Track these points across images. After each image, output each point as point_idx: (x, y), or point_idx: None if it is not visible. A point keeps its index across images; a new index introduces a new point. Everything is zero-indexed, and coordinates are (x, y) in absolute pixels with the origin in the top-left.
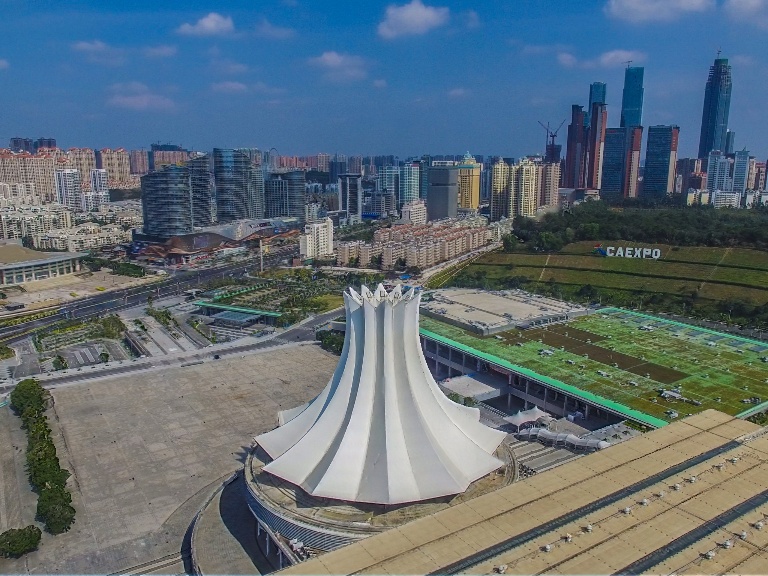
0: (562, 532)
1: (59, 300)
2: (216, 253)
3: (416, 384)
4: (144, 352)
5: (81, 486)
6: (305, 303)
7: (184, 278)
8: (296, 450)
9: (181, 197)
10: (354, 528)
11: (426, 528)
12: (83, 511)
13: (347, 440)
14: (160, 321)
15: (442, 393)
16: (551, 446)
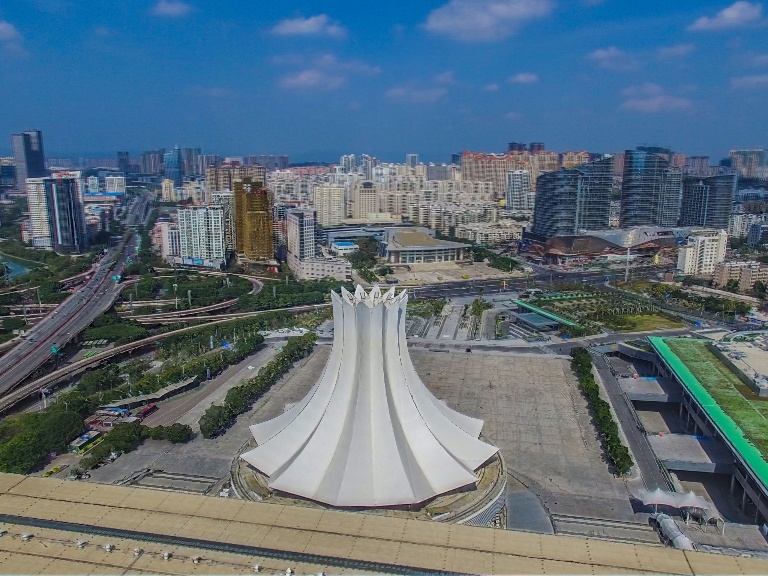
0: (299, 567)
1: (425, 281)
2: (598, 258)
3: (376, 391)
4: (422, 333)
5: (255, 414)
6: (612, 319)
7: (544, 278)
8: (277, 420)
9: (566, 199)
10: (250, 497)
11: (224, 507)
12: (235, 430)
13: (297, 423)
14: (472, 311)
15: (416, 411)
16: (663, 543)
